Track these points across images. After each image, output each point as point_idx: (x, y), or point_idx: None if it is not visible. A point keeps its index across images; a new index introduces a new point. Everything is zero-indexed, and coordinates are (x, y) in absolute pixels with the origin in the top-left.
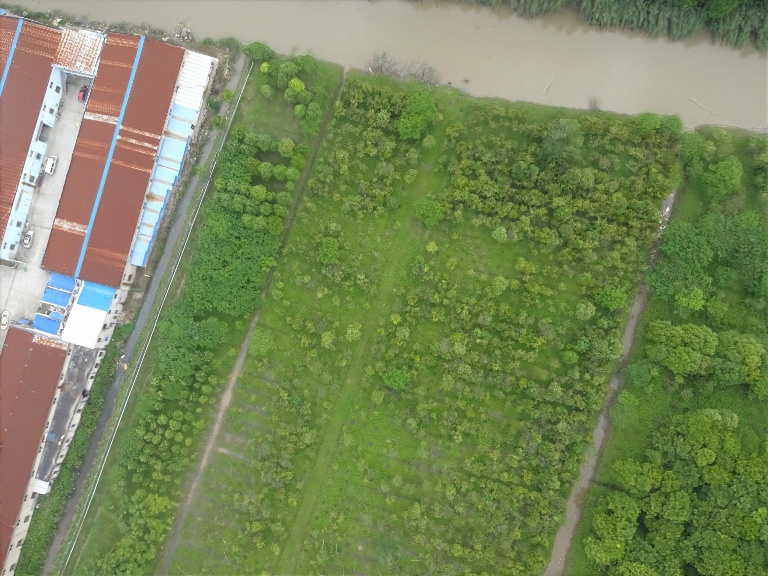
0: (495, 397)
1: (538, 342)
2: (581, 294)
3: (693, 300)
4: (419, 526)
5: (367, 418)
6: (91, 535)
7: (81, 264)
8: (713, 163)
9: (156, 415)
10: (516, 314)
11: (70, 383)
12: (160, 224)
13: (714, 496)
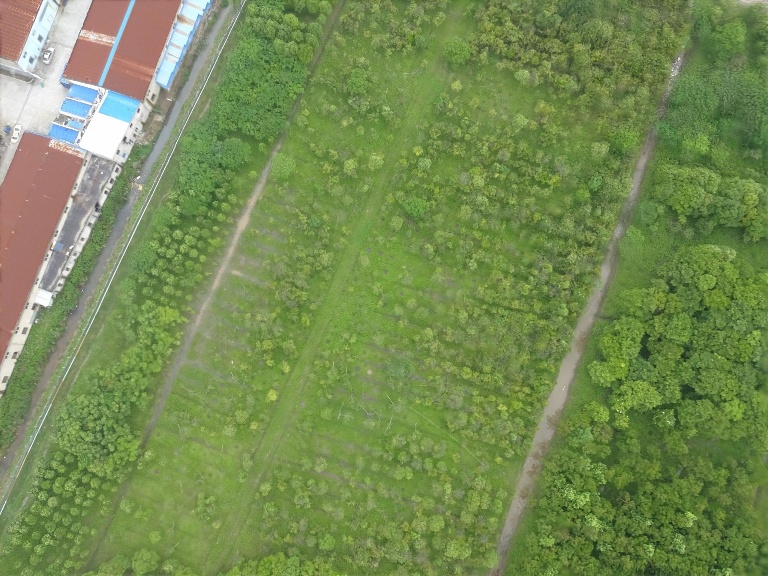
0: (511, 225)
1: (553, 179)
2: (596, 133)
3: (700, 140)
4: (430, 349)
5: (384, 246)
6: (92, 351)
7: (106, 73)
8: (720, 25)
9: (171, 230)
10: (533, 153)
11: (83, 195)
12: (187, 50)
13: (713, 318)
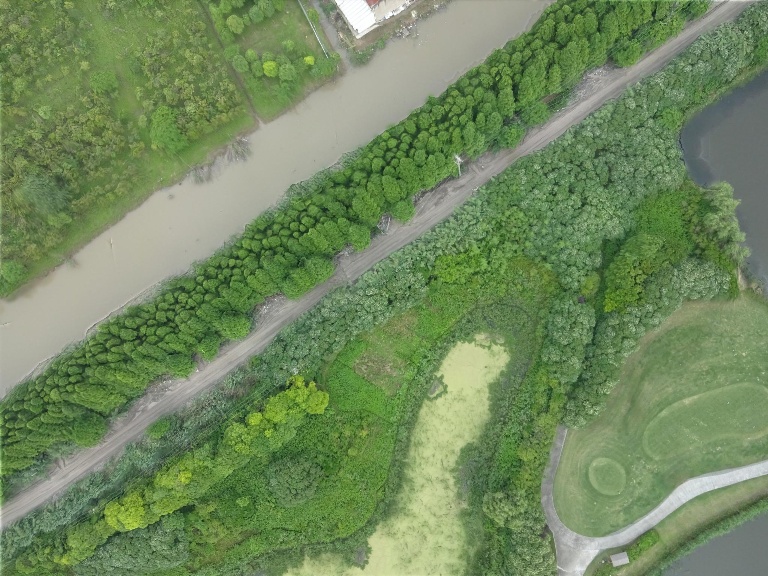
0: None
1: None
2: None
3: None
4: None
5: None
6: None
7: None
8: None
9: None
10: None
11: None
12: None
13: None
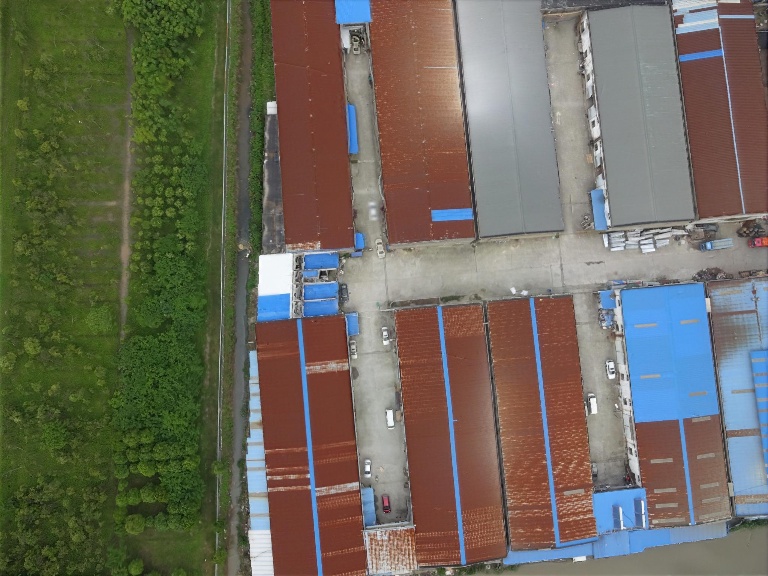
0: None
1: None
2: None
3: None
4: None
5: None
6: (212, 82)
7: (299, 334)
8: None
9: None
10: None
11: (279, 214)
12: None
13: None
